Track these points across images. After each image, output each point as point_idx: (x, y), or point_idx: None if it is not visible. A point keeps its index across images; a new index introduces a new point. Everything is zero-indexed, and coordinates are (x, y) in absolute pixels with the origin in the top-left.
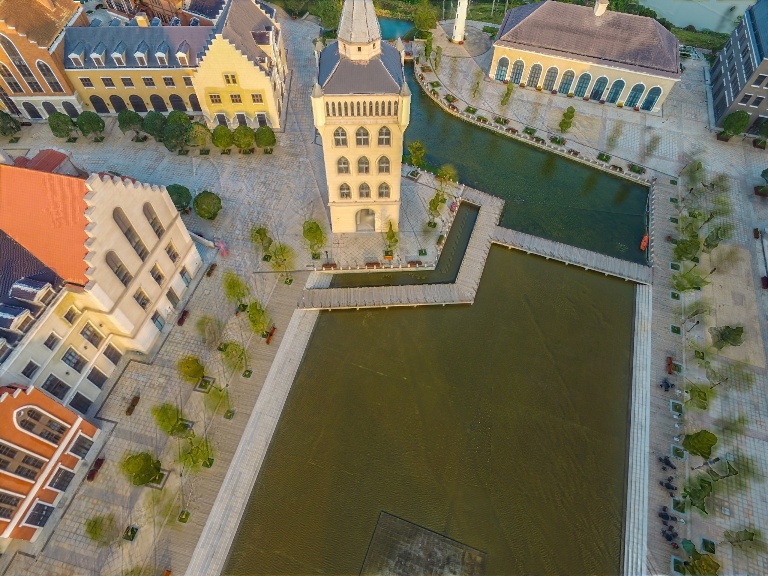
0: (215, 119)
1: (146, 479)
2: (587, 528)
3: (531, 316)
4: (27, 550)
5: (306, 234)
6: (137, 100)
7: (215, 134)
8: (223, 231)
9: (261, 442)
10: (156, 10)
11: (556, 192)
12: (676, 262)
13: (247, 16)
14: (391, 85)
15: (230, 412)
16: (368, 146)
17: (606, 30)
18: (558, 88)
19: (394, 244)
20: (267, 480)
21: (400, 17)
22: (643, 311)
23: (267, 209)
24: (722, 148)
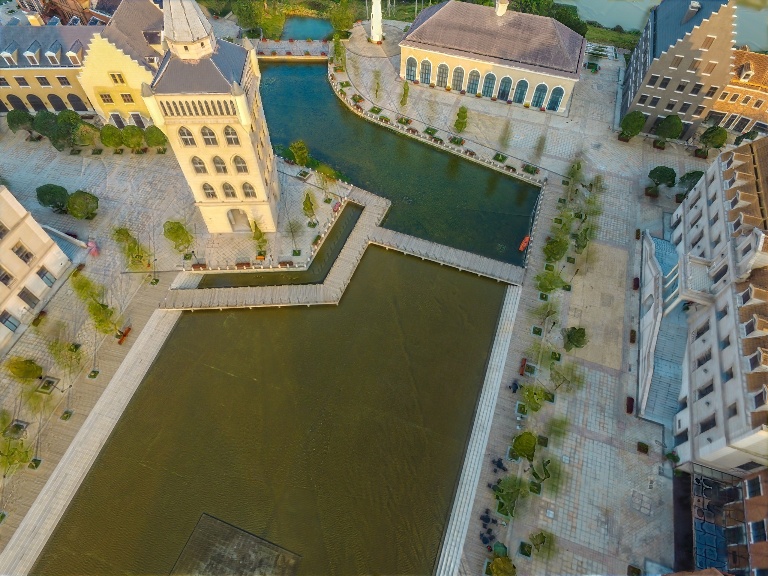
0: (110, 119)
1: None
2: (408, 531)
3: (395, 317)
4: None
5: (166, 234)
6: (35, 100)
7: (102, 134)
8: (99, 231)
9: (95, 443)
10: (65, 9)
11: (446, 192)
12: (551, 263)
13: (140, 15)
14: (223, 84)
15: (67, 413)
16: (218, 146)
17: (507, 30)
18: (466, 88)
19: (264, 244)
20: (94, 482)
21: (326, 17)
22: (508, 312)
23: (148, 209)
24: (621, 149)
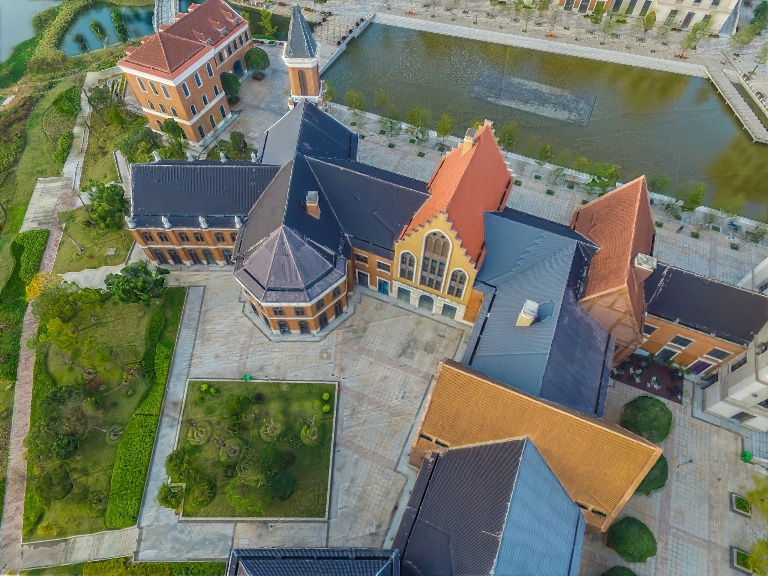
0: None
1: (593, 18)
2: None
3: (760, 171)
4: (555, 8)
5: (765, 43)
6: None
7: None
8: None
9: (617, 59)
10: None
11: None
12: None
13: None
14: None
15: (629, 47)
16: None
17: None
18: None
19: None
20: (599, 63)
21: None
22: None
23: None
24: None
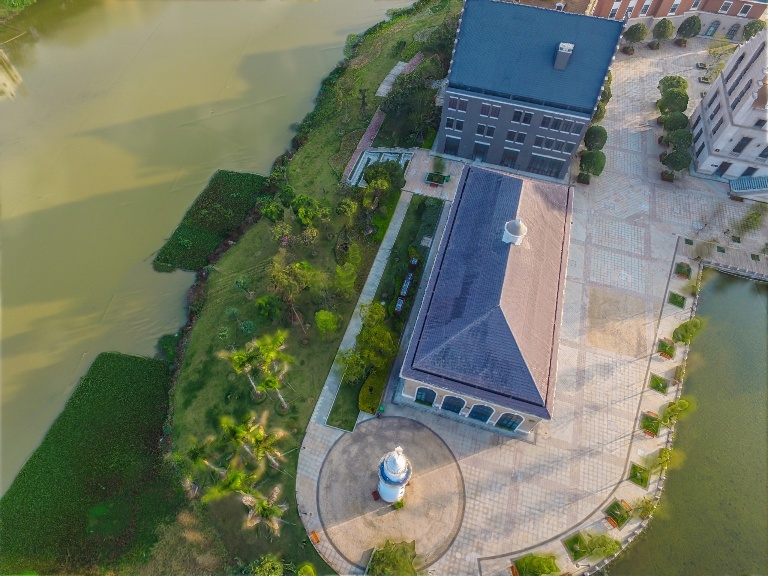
0: None
1: None
2: None
3: None
4: None
5: None
6: None
7: None
8: None
9: None
10: None
11: (767, 368)
12: None
13: None
14: None
15: None
16: None
17: (535, 240)
18: None
19: None
20: None
21: None
22: None
23: None
24: (603, 185)
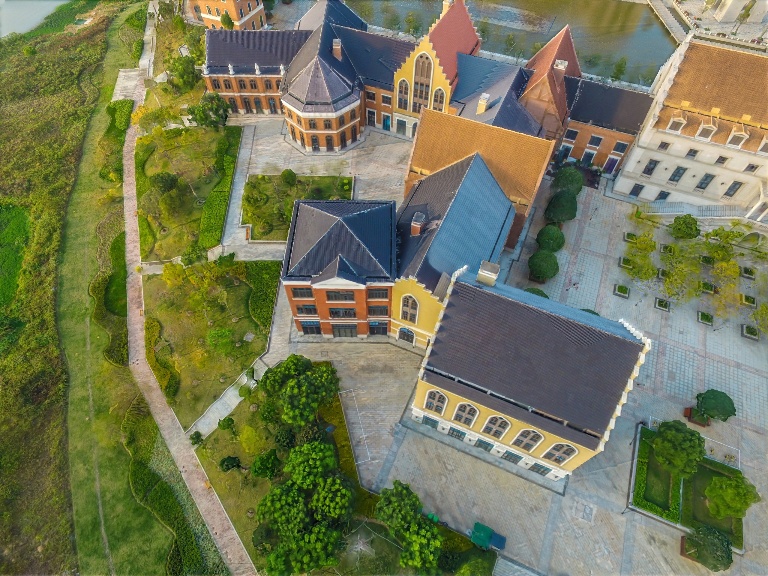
0: None
1: None
2: None
3: None
4: None
5: None
6: None
7: None
8: None
9: None
10: None
11: None
12: None
13: None
14: None
15: None
16: None
17: None
18: None
19: None
20: None
21: None
22: None
23: None
24: None
